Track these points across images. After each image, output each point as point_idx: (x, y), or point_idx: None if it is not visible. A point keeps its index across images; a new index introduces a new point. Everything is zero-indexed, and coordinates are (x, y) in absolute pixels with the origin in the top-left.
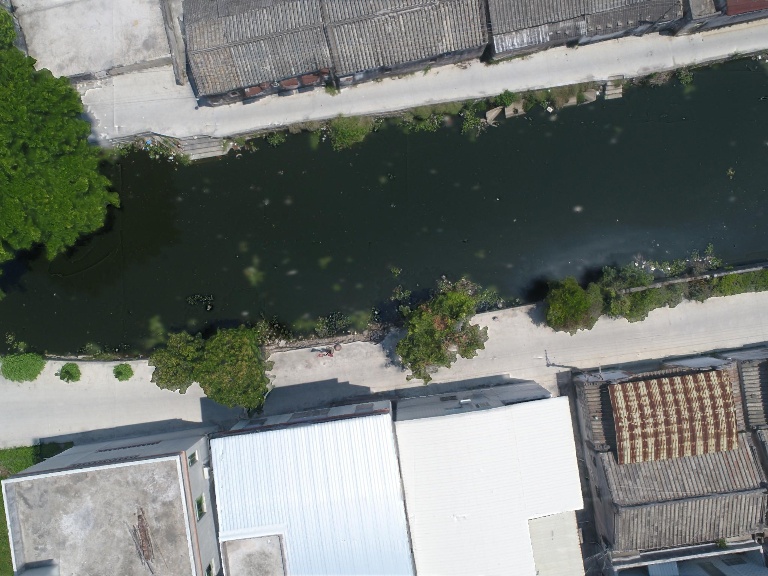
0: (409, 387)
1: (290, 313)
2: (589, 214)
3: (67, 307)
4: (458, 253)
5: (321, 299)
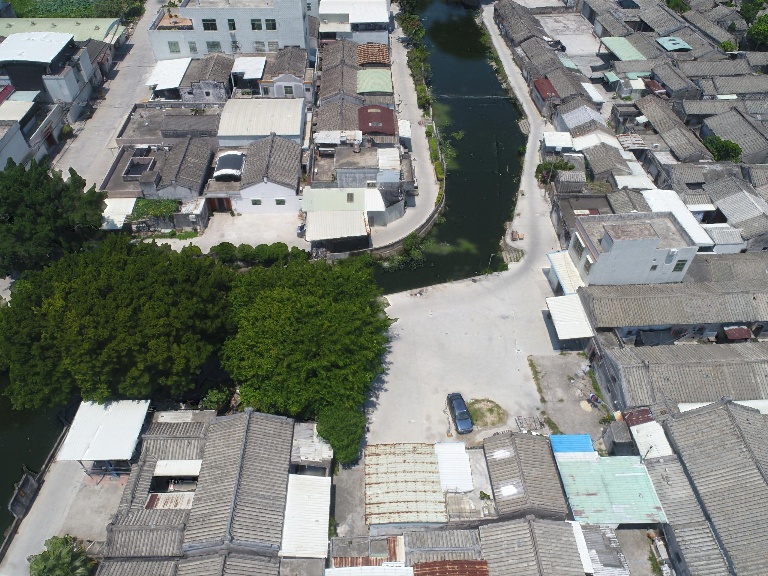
0: (390, 39)
1: None
2: None
3: (426, 2)
4: (439, 56)
5: None
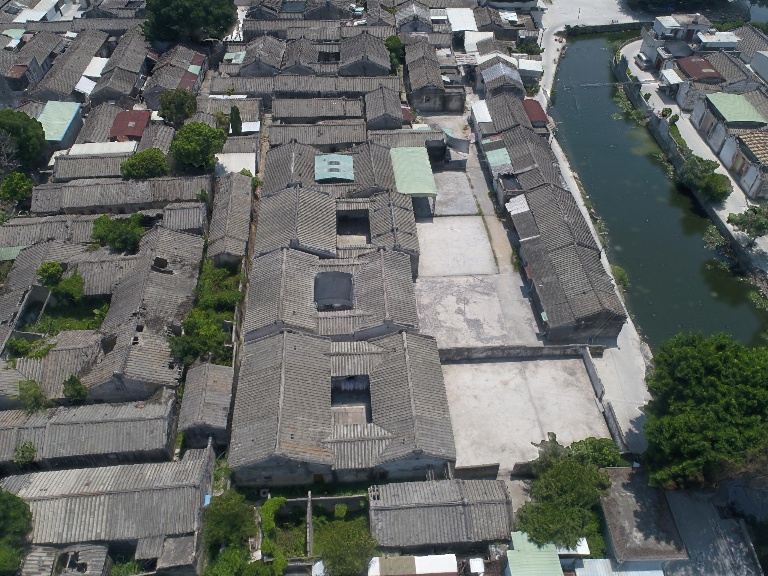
0: None
1: (760, 323)
2: (647, 190)
3: None
4: (687, 240)
5: (743, 305)
